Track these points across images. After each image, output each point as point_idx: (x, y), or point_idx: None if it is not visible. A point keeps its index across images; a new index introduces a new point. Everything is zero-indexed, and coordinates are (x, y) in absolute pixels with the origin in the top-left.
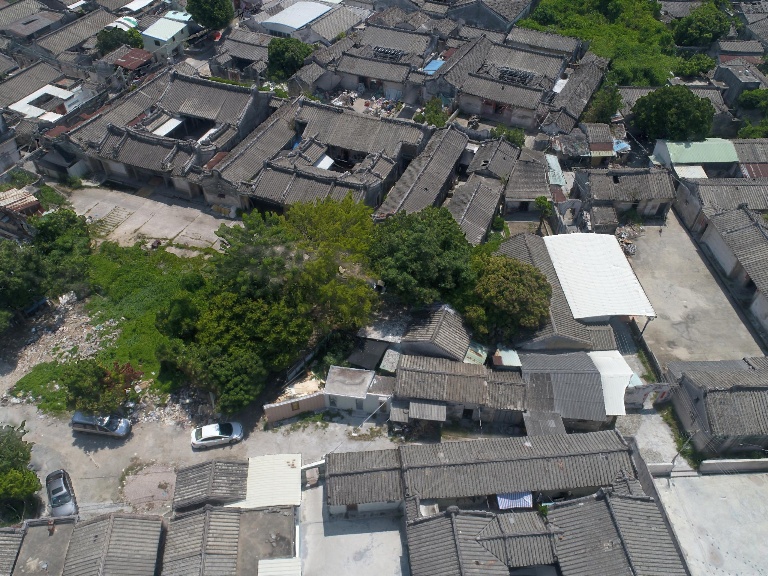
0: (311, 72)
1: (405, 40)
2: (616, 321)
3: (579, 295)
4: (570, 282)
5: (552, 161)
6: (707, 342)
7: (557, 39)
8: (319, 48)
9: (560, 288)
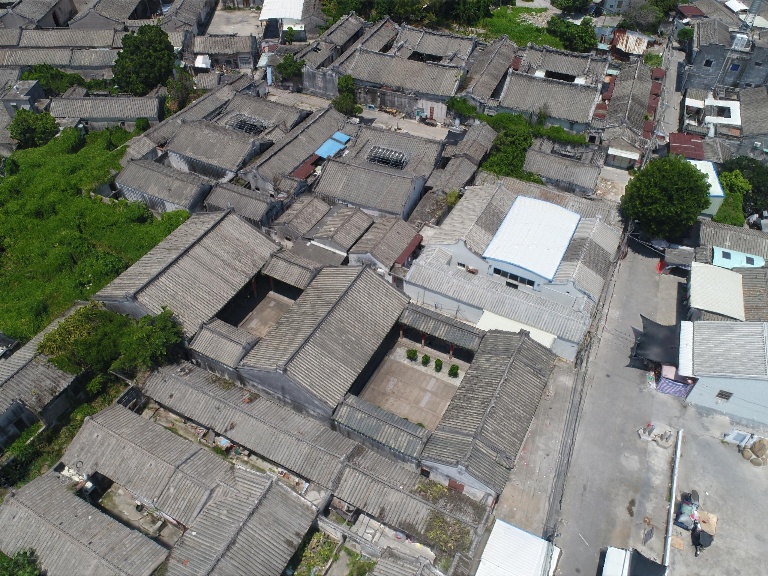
0: (474, 135)
1: (363, 166)
2: (275, 23)
3: (297, 1)
4: (298, 5)
5: (263, 62)
6: (237, 17)
7: (155, 168)
8: (477, 177)
9: (304, 5)
